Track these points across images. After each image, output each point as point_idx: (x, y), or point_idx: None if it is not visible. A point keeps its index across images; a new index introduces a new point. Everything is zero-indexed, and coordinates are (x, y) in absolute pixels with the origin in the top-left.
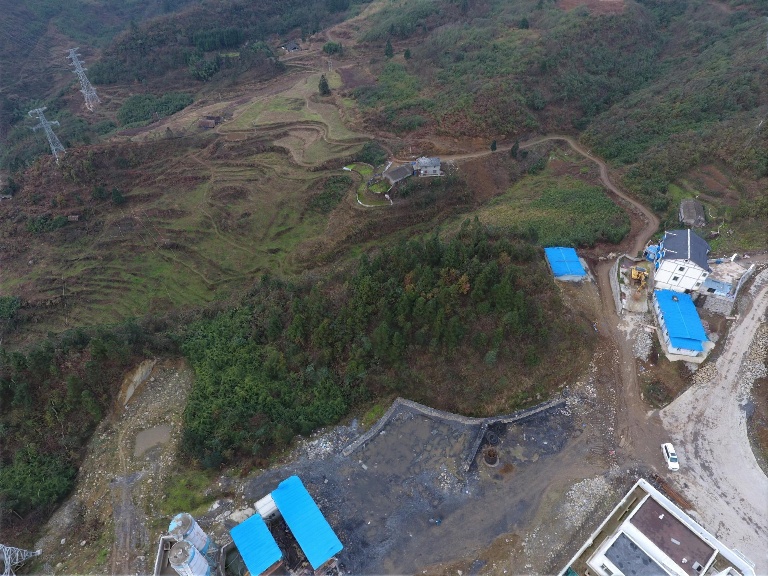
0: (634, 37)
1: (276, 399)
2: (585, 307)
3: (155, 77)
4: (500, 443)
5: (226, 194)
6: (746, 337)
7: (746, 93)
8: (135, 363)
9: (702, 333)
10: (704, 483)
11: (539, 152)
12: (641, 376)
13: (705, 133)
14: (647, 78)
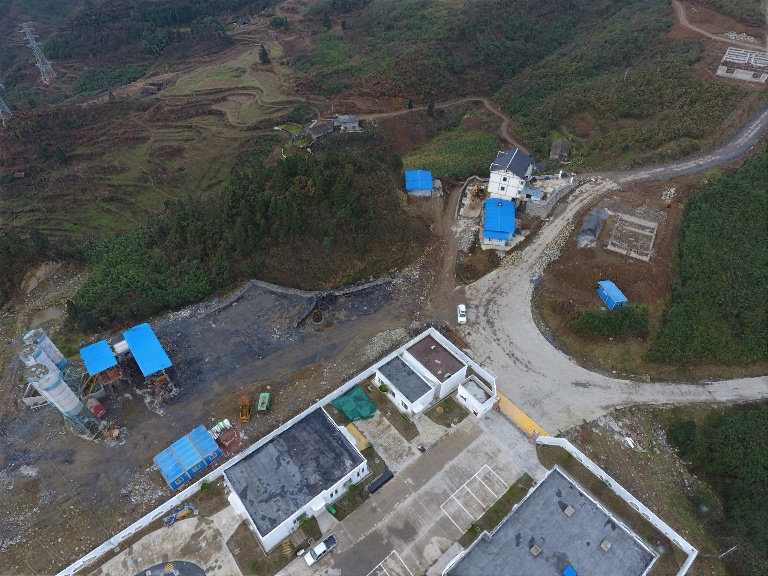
0: (551, 6)
1: (154, 285)
2: (425, 213)
3: (109, 52)
4: (329, 309)
5: (164, 152)
6: (553, 232)
7: (631, 51)
8: (38, 261)
9: (512, 227)
10: (484, 332)
11: (456, 111)
12: (459, 262)
13: (586, 85)
14: (561, 44)
